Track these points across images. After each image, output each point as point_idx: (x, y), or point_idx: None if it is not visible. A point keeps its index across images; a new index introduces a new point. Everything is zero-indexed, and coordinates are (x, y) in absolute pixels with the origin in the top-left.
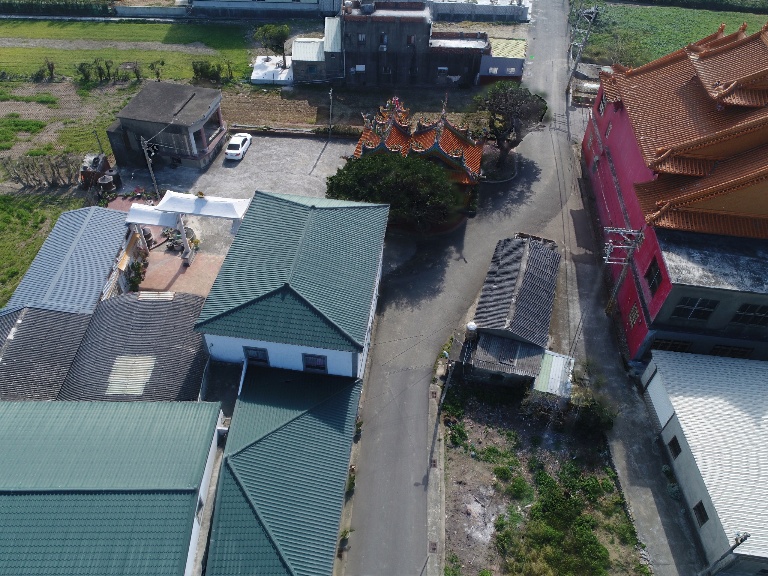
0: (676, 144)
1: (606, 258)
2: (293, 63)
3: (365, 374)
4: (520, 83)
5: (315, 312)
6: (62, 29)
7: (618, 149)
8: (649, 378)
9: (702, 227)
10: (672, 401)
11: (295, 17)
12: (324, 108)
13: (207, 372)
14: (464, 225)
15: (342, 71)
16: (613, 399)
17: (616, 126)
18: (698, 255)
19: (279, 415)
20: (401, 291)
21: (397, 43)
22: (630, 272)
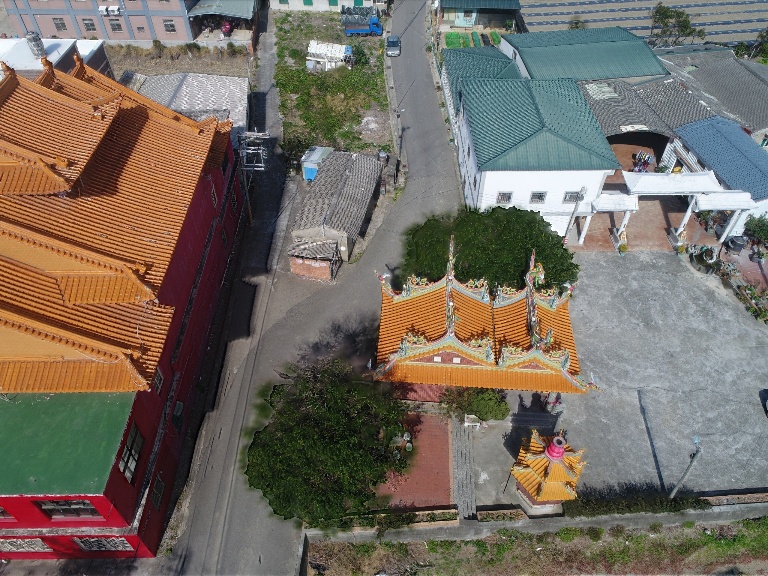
0: None
1: None
2: None
3: None
4: None
5: None
6: None
7: None
8: None
9: None
10: None
11: None
12: None
13: None
14: None
15: None
16: (271, 172)
17: None
18: None
19: None
20: None
21: None
22: None
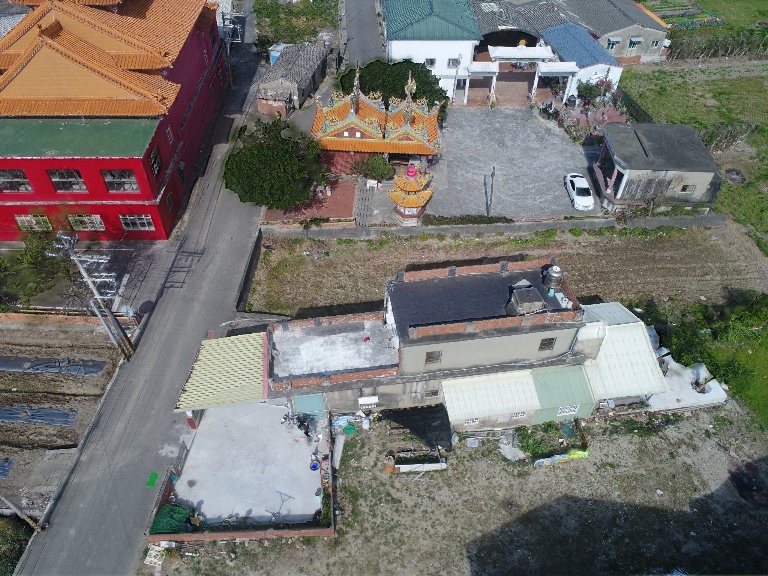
0: None
1: None
2: None
3: None
4: None
5: None
6: None
7: None
8: None
9: None
10: None
11: None
12: None
13: None
14: None
15: None
16: (248, 62)
17: None
18: None
19: None
20: None
21: None
22: None
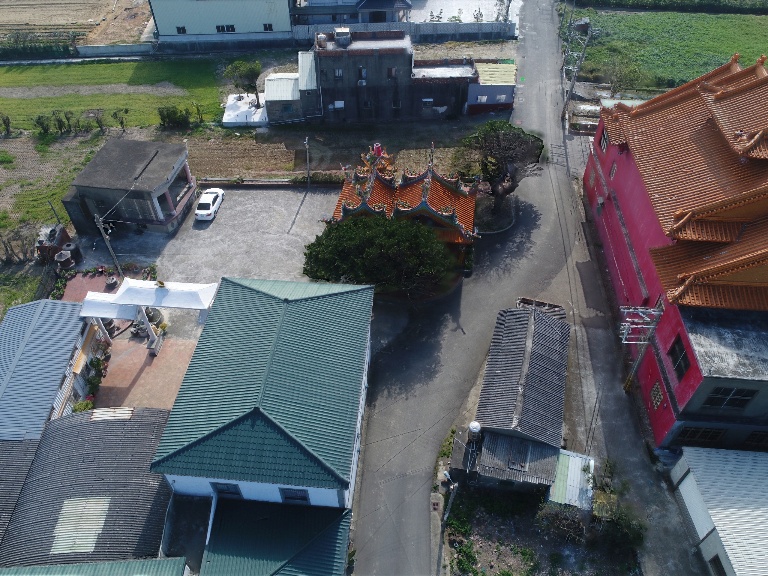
0: (696, 205)
1: (623, 337)
2: (266, 103)
3: (356, 484)
4: (512, 110)
5: (291, 441)
6: (21, 75)
7: (626, 196)
8: (681, 477)
9: (733, 303)
10: (712, 515)
11: (268, 47)
12: (302, 151)
13: (170, 512)
14: (460, 287)
15: (320, 109)
16: (640, 501)
17: (622, 169)
18: (730, 336)
19: (254, 570)
20: (393, 374)
21: (377, 76)
22: (650, 345)
